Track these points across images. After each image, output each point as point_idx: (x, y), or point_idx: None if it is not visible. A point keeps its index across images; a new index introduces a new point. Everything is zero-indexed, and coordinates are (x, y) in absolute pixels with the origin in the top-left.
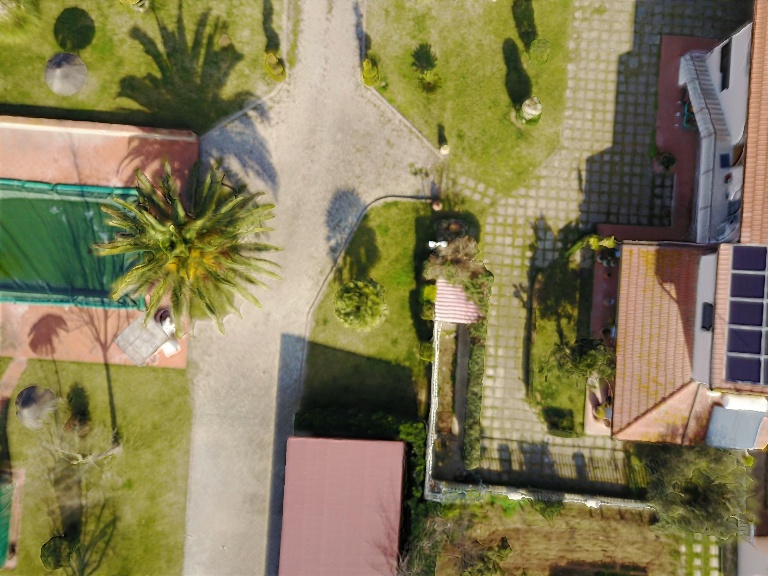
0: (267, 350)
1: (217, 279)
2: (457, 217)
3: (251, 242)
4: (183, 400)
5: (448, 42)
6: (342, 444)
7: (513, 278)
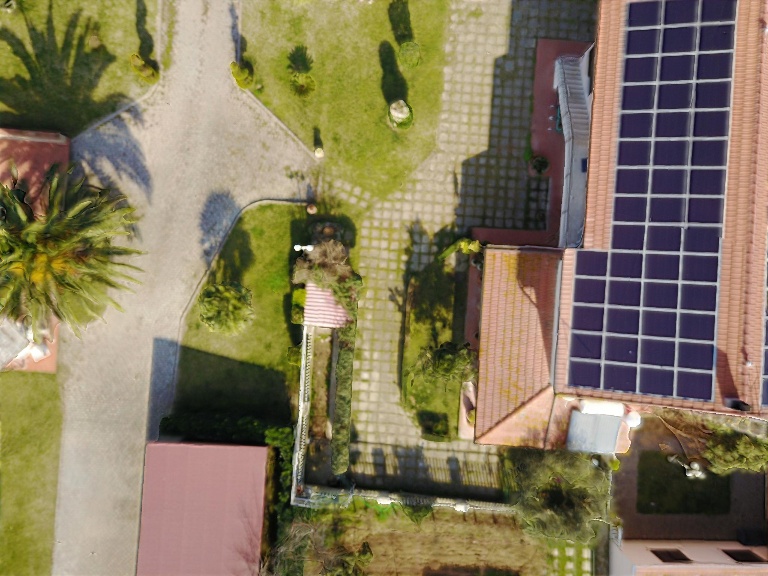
0: (139, 354)
1: (61, 284)
2: (333, 220)
3: (109, 246)
4: (53, 405)
5: (324, 44)
6: (203, 449)
7: (389, 282)
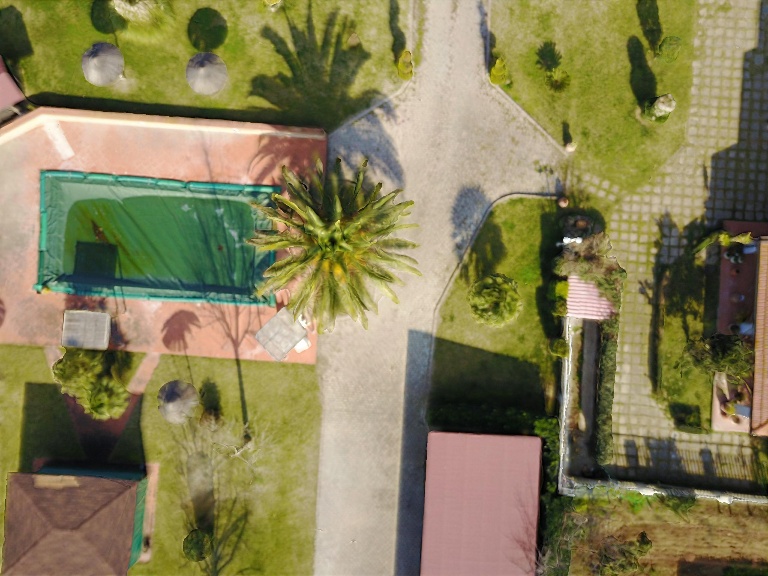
0: (395, 346)
1: (372, 274)
2: (582, 214)
3: (393, 238)
4: (313, 395)
5: (573, 40)
6: (481, 439)
7: (638, 274)
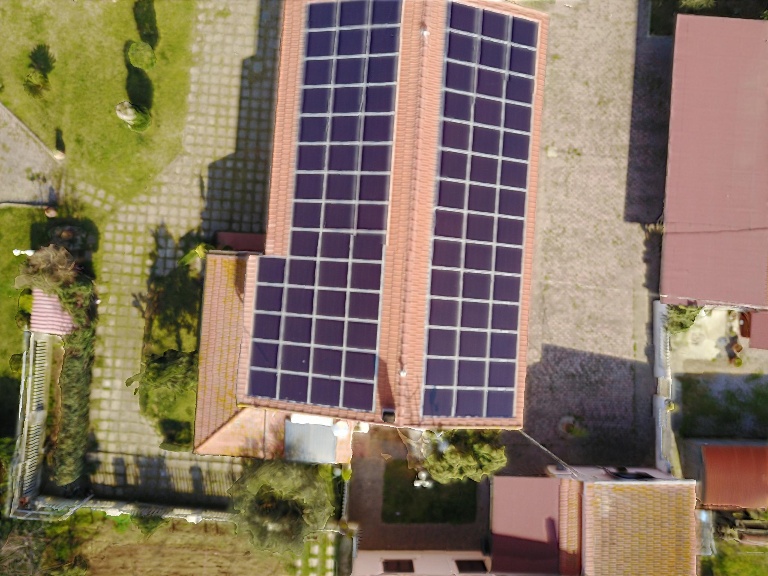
0: None
1: None
2: (74, 224)
3: None
4: None
5: (66, 43)
6: None
7: (133, 287)
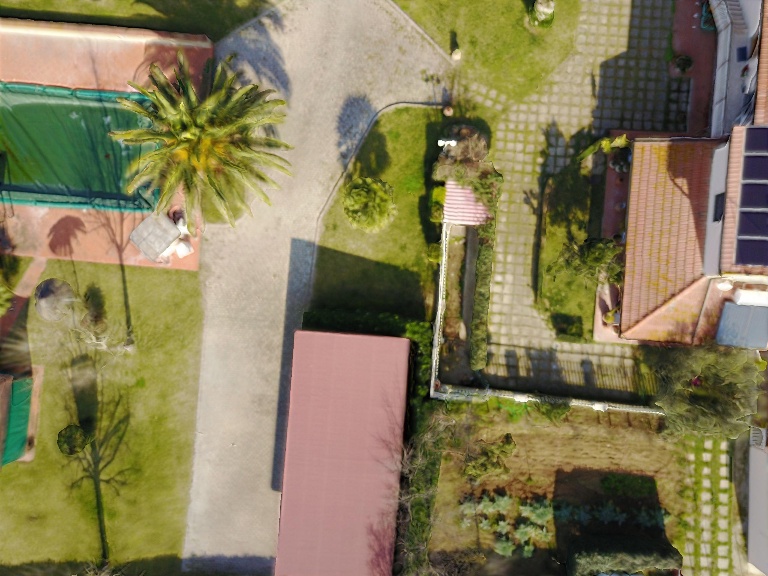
0: (278, 254)
1: (226, 163)
2: (468, 123)
3: (261, 137)
4: (195, 301)
5: None
6: (349, 339)
7: (524, 185)
